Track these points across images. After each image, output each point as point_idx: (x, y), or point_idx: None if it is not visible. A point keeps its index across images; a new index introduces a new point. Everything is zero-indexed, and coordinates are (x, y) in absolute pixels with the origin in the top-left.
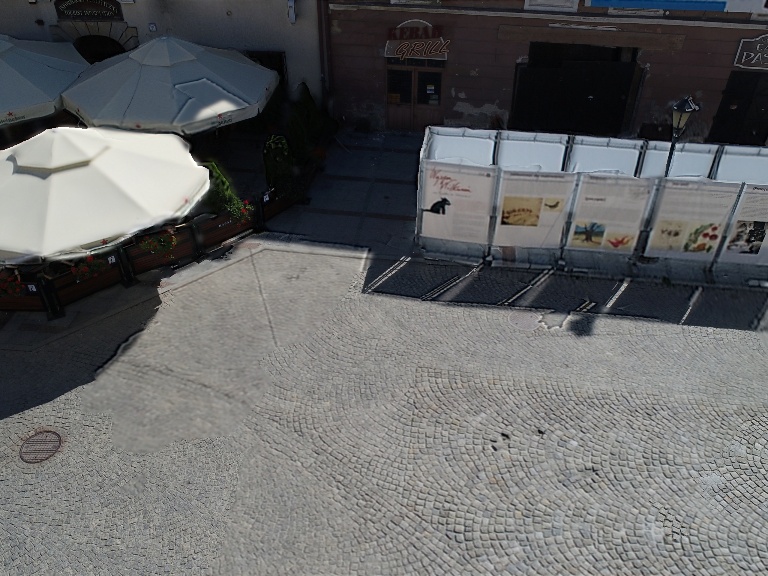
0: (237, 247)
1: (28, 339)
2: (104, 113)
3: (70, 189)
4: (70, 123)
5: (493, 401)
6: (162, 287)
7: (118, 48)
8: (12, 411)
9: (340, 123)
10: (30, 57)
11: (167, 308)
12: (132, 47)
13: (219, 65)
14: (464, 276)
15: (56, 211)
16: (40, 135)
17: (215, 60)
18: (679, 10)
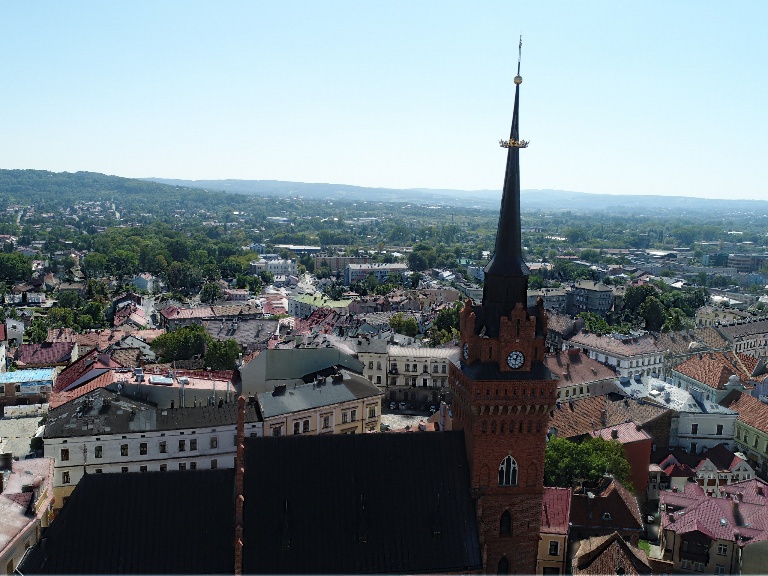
0: None
1: None
2: None
3: None
4: None
5: None
6: None
7: None
8: None
9: None
10: None
11: None
12: None
13: None
14: None
15: None
16: None
17: None
18: (32, 394)
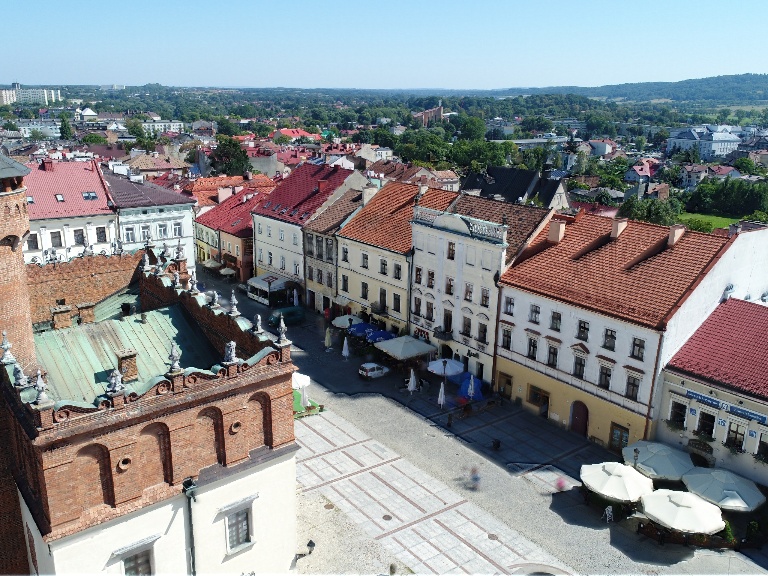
0: (726, 552)
1: (652, 547)
2: (697, 490)
3: (684, 513)
4: (682, 486)
5: None
6: (696, 552)
7: (706, 462)
8: (646, 563)
9: None
10: (676, 458)
11: (696, 559)
12: (712, 464)
13: (743, 488)
14: None
15: (679, 517)
16: (680, 494)
17: (742, 485)
18: None
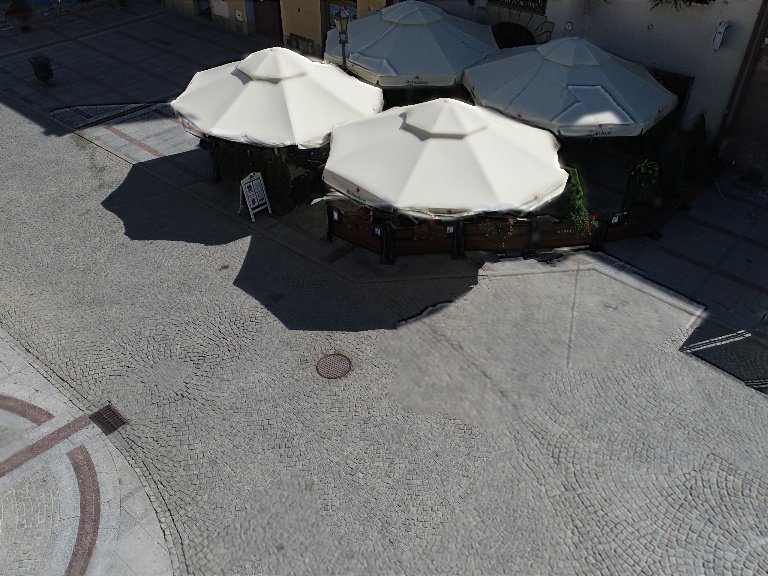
0: (567, 257)
1: (359, 273)
2: (494, 96)
3: (439, 155)
4: (462, 97)
5: None
6: (483, 270)
7: (530, 39)
8: (325, 327)
9: (727, 167)
10: (452, 31)
11: (480, 290)
12: (543, 41)
13: (619, 76)
14: None
15: (421, 171)
16: (433, 101)
17: (617, 70)
18: None
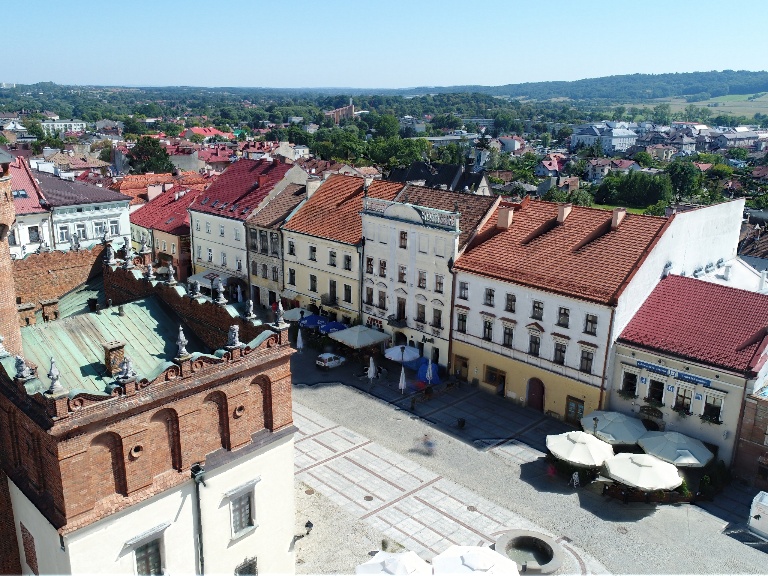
0: (683, 506)
1: (618, 506)
2: (653, 451)
3: (646, 472)
4: (639, 449)
5: (752, 572)
6: (657, 508)
7: (657, 426)
8: None
9: (735, 478)
10: (631, 424)
11: (658, 514)
12: (662, 427)
13: (693, 447)
14: (761, 543)
15: (642, 476)
16: (640, 455)
17: (692, 444)
18: None
